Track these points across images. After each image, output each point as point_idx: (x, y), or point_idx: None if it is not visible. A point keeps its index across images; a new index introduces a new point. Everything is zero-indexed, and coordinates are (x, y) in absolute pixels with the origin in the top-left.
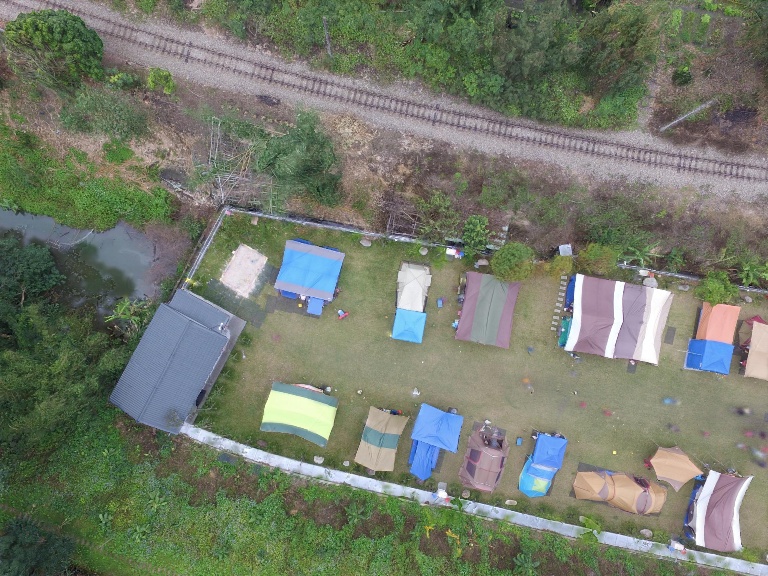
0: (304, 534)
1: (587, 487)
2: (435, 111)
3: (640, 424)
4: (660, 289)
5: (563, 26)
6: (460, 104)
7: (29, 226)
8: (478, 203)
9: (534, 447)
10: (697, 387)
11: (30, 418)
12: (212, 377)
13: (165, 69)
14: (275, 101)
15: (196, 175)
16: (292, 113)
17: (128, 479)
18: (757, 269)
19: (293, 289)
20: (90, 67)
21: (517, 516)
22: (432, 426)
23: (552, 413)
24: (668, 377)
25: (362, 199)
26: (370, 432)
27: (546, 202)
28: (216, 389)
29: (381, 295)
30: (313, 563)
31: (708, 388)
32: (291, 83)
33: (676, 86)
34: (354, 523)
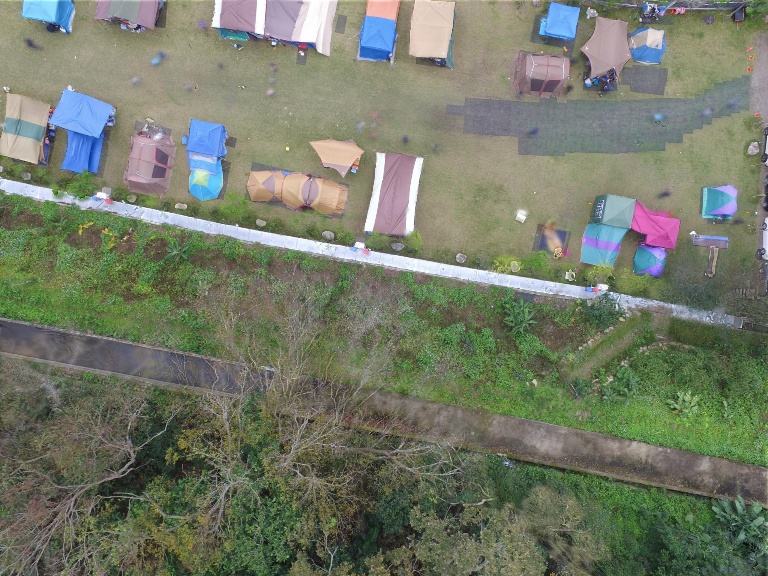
0: None
1: (254, 181)
2: None
3: (314, 119)
4: None
5: None
6: None
7: None
8: None
9: None
10: (373, 78)
11: None
12: None
13: None
14: None
15: None
16: None
17: None
18: None
19: None
20: None
21: (189, 221)
22: (73, 112)
23: (219, 110)
24: (341, 68)
25: None
26: (8, 121)
27: None
28: None
29: None
30: None
31: (385, 79)
32: None
33: None
34: None
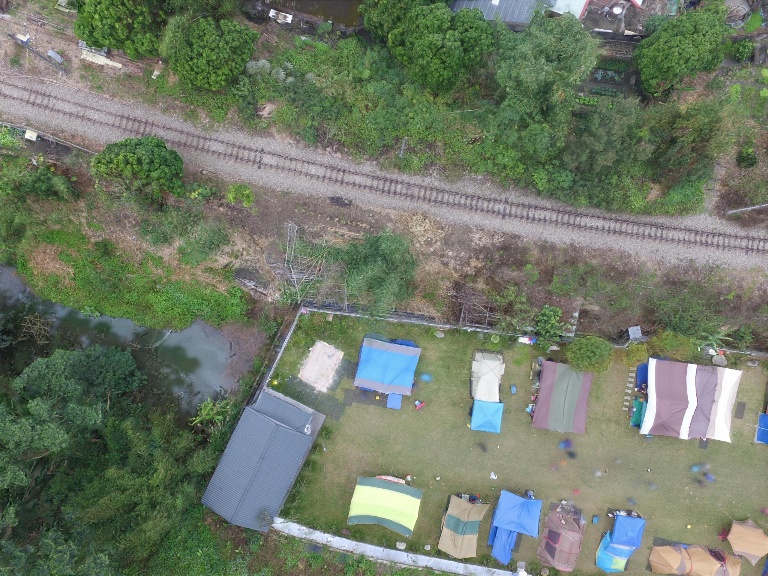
0: None
1: (664, 563)
2: (504, 205)
3: (713, 498)
4: (731, 369)
5: None
6: (529, 196)
7: (108, 329)
8: (549, 291)
9: (612, 528)
10: (767, 459)
11: (137, 536)
12: None
13: (238, 176)
14: (347, 202)
15: (269, 273)
16: (364, 213)
17: None
18: None
19: (373, 386)
20: (173, 187)
21: None
22: (513, 512)
23: (626, 491)
24: (739, 451)
25: (433, 291)
26: (452, 520)
27: (616, 288)
28: (299, 482)
29: (455, 384)
30: None
31: None
32: (362, 184)
33: (741, 168)
34: None
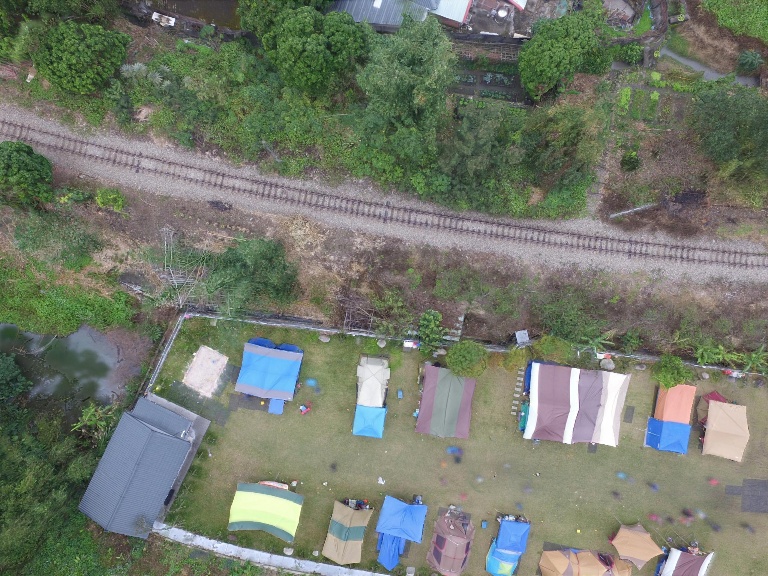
0: None
1: (552, 567)
2: (386, 209)
3: (602, 502)
4: (616, 373)
5: (507, 124)
6: (410, 200)
7: None
8: (433, 296)
9: (497, 533)
10: (657, 463)
11: None
12: (180, 476)
13: (117, 180)
14: (227, 206)
15: (155, 278)
16: (244, 217)
17: None
18: (711, 350)
19: (253, 392)
20: (39, 192)
21: None
22: (396, 518)
23: (515, 495)
24: (628, 455)
25: (319, 295)
26: (336, 526)
27: (500, 292)
28: (184, 488)
29: (342, 388)
30: None
31: (668, 464)
32: (242, 188)
33: (624, 171)
34: None
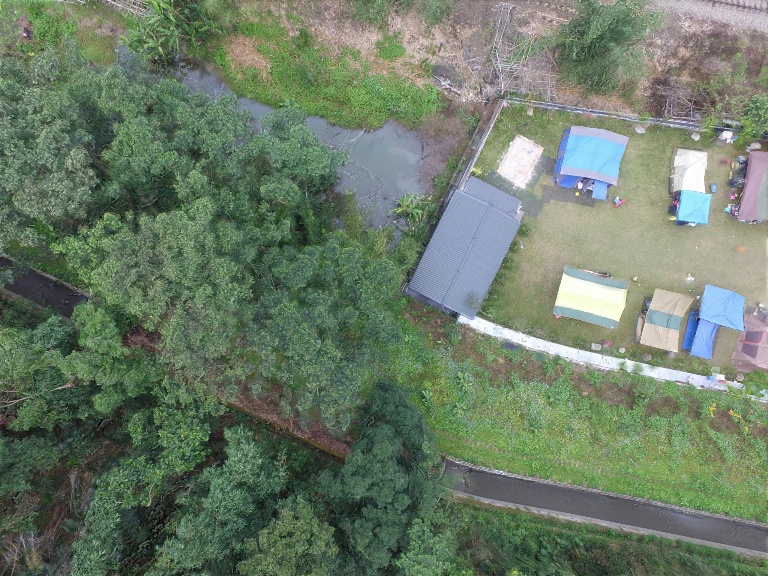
0: (601, 413)
1: None
2: None
3: None
4: None
5: None
6: None
7: None
8: (754, 85)
9: None
10: None
11: None
12: None
13: None
14: None
15: (466, 70)
16: None
17: (431, 362)
18: None
19: (582, 173)
20: None
21: None
22: (718, 306)
23: None
24: None
25: (635, 87)
26: (656, 314)
27: None
28: (496, 279)
29: (654, 182)
30: (618, 438)
31: None
32: None
33: None
34: (643, 403)
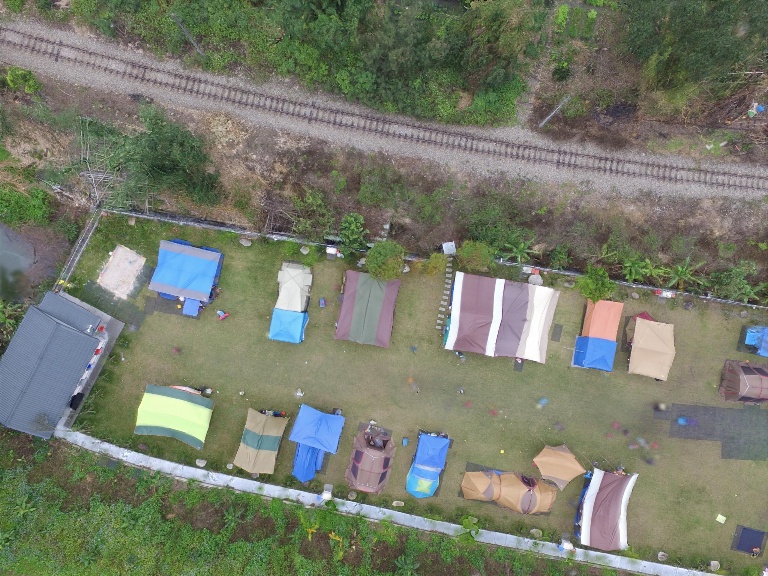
0: (179, 539)
1: (473, 487)
2: (311, 109)
3: (528, 423)
4: (542, 286)
5: (433, 22)
6: (336, 101)
7: None
8: (358, 201)
9: None
10: (585, 385)
11: None
12: (90, 380)
13: (35, 68)
14: (148, 100)
15: (74, 175)
16: (165, 112)
17: None
18: (638, 265)
19: (166, 290)
20: None
21: (405, 517)
22: (311, 427)
23: (438, 413)
24: (555, 375)
25: (242, 198)
26: (249, 434)
27: (426, 199)
28: (95, 392)
29: (263, 295)
30: (185, 568)
31: (596, 385)
32: (164, 81)
33: (555, 82)
34: (233, 527)
